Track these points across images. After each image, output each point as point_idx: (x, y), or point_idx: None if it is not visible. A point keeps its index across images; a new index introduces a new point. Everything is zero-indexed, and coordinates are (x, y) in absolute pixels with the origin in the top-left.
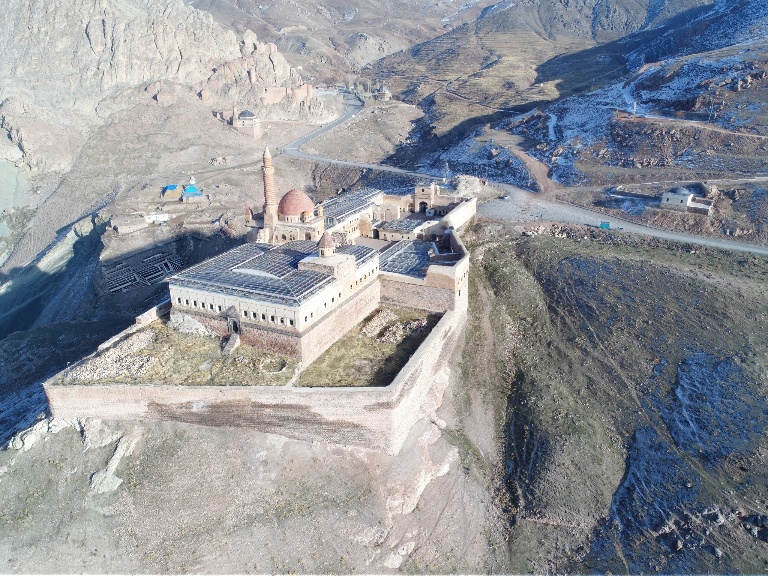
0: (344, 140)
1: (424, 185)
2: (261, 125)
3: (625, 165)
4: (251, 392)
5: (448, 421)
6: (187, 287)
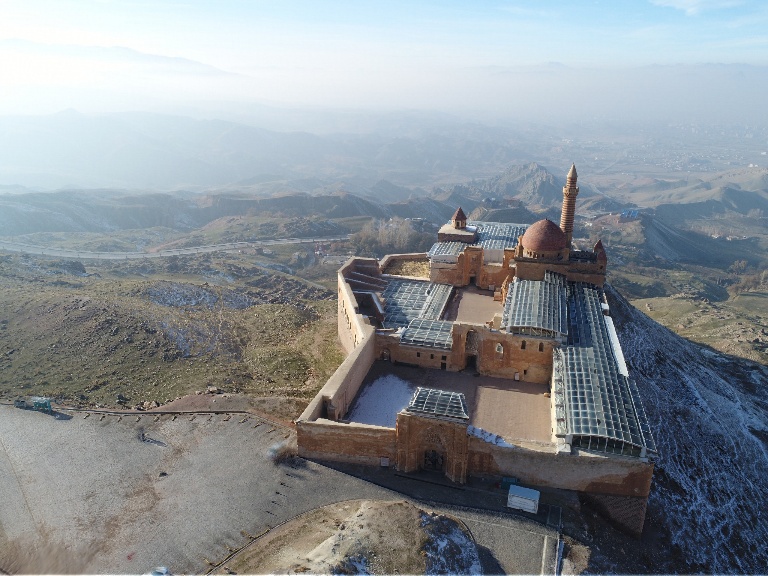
0: None
1: (436, 391)
2: None
3: None
4: None
5: None
6: None
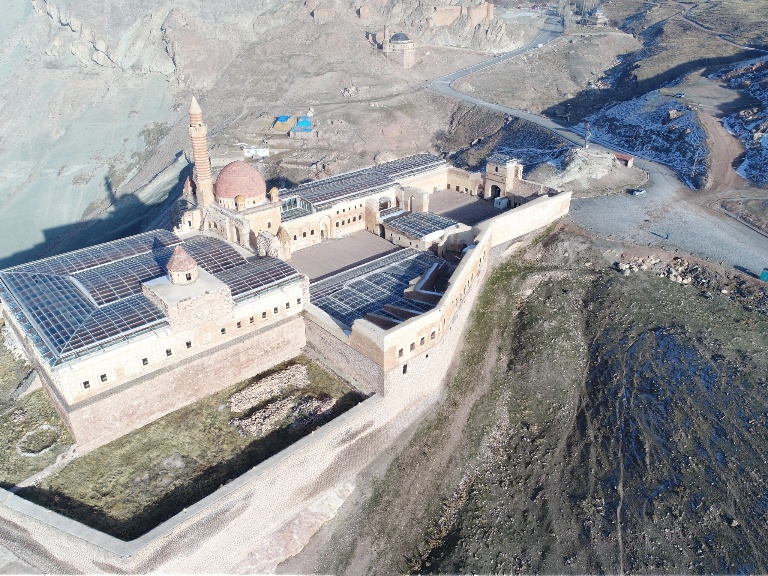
0: (514, 75)
1: (498, 162)
2: (416, 51)
3: None
4: None
5: None
6: None
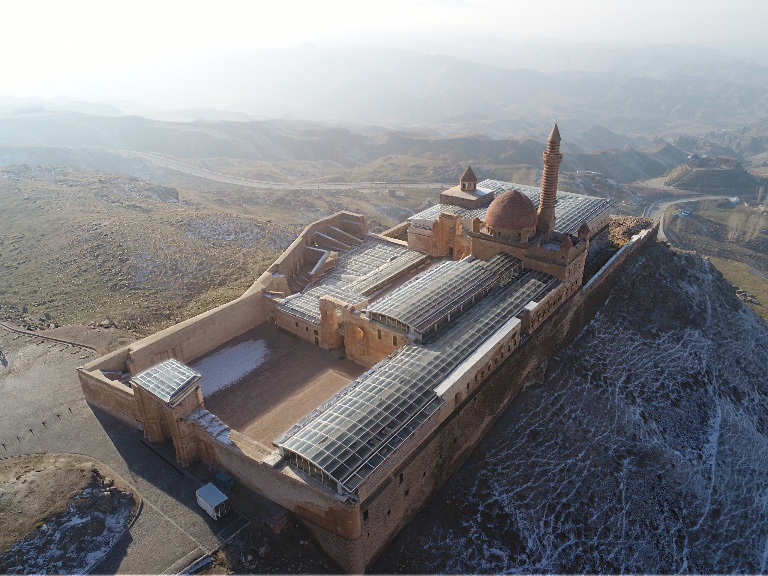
0: None
1: (184, 367)
2: None
3: None
4: None
5: None
6: None
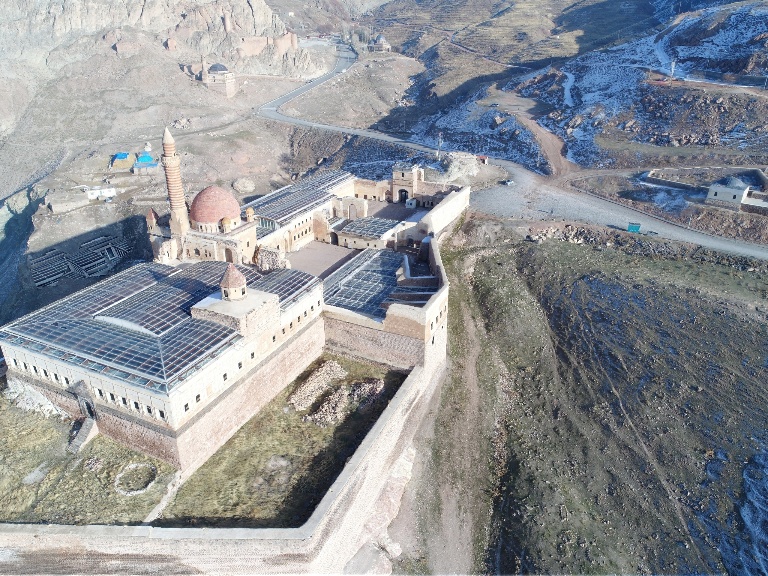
0: (331, 99)
1: (404, 169)
2: (235, 81)
3: (658, 142)
4: (84, 538)
5: (405, 543)
6: (21, 346)
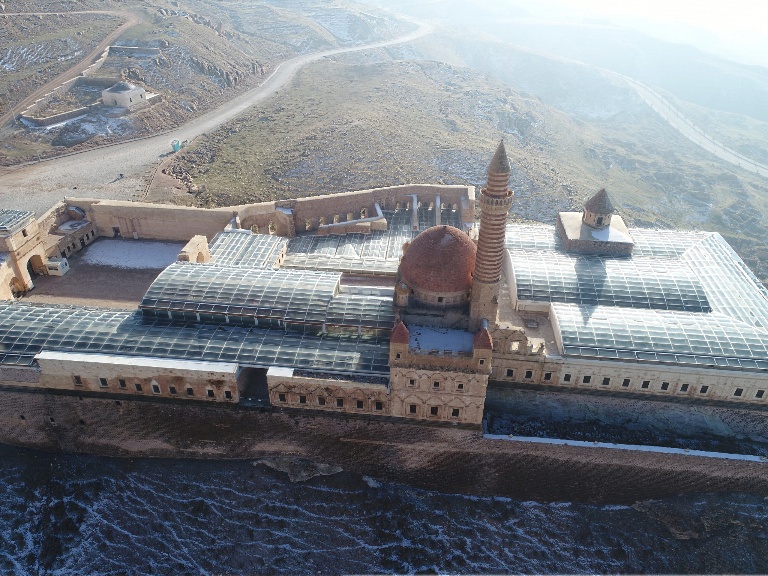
0: None
1: (25, 220)
2: None
3: None
4: None
5: None
6: None
